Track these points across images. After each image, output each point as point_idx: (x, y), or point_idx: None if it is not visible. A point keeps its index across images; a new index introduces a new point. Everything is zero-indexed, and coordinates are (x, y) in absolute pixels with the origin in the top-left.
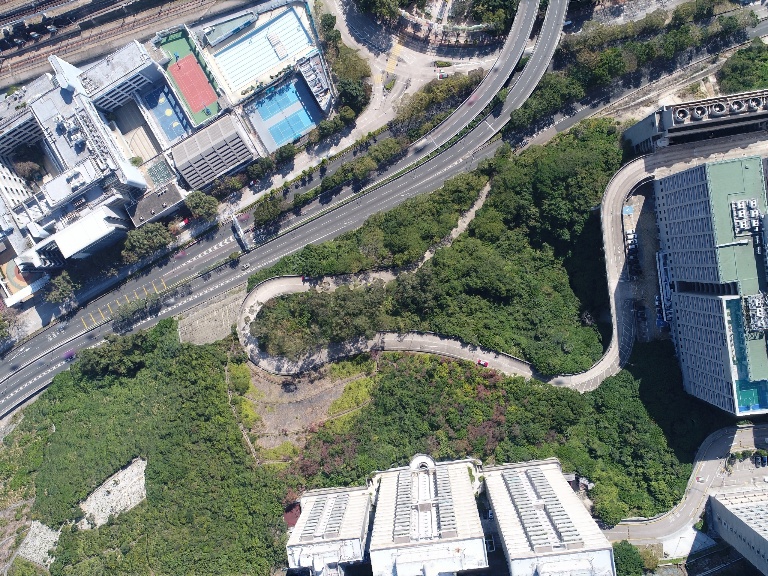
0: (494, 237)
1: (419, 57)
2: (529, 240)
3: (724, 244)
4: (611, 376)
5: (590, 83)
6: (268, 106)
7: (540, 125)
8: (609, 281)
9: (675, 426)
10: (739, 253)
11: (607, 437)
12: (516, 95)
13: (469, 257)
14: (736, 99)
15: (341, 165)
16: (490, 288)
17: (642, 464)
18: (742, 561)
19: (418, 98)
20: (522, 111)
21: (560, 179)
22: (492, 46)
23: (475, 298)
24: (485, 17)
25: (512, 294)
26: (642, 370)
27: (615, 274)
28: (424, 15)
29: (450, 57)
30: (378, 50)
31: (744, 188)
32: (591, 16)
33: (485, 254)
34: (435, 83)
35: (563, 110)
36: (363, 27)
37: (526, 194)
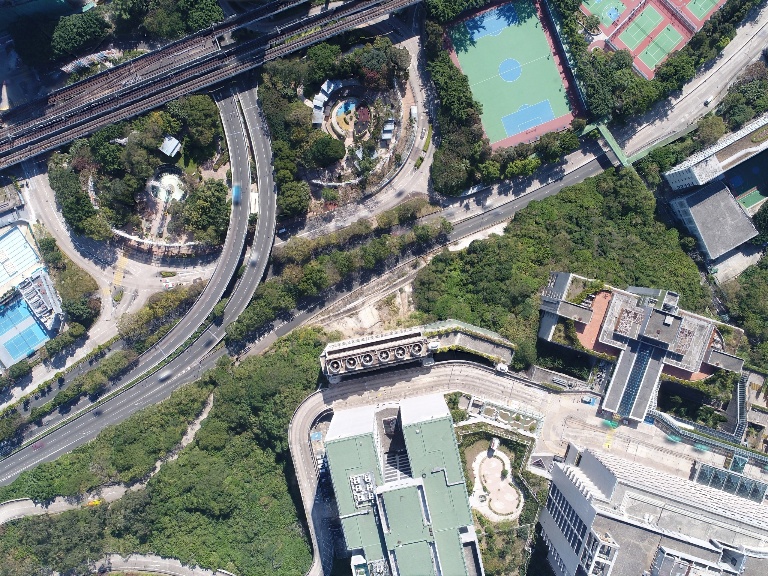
0: None
1: (144, 268)
2: (257, 442)
3: (346, 515)
4: None
5: (300, 293)
6: (1, 322)
7: (261, 332)
8: (305, 503)
9: None
10: (362, 522)
11: None
12: (235, 305)
13: (192, 471)
14: (383, 349)
15: (73, 379)
16: (204, 508)
17: None
18: None
19: (134, 320)
20: (235, 326)
21: (269, 395)
22: (214, 255)
23: (195, 515)
24: (196, 236)
25: (225, 512)
26: None
27: (310, 496)
28: (145, 229)
29: (174, 267)
30: (104, 264)
31: (360, 463)
32: (304, 223)
33: (205, 468)
34: (153, 300)
35: (281, 316)
36: (88, 242)
37: (244, 405)
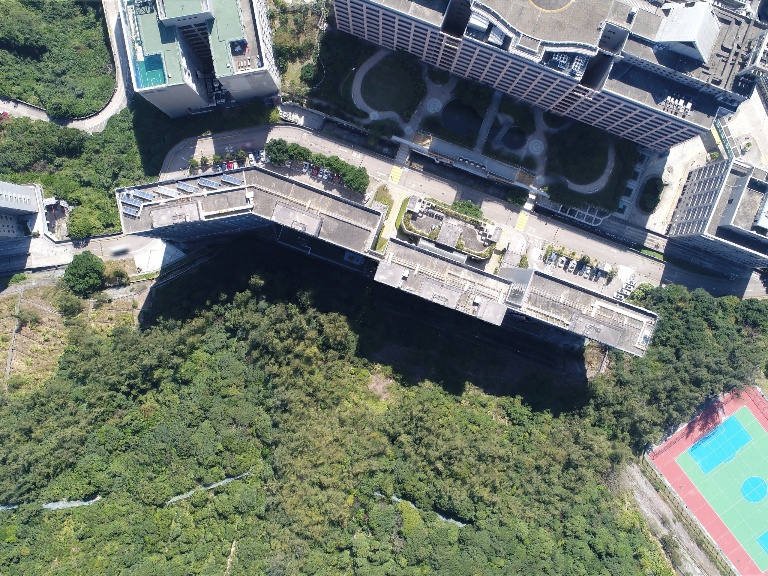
0: (41, 3)
1: None
2: (81, 9)
3: None
4: (116, 114)
5: None
6: None
7: None
8: (108, 18)
9: (151, 146)
10: None
11: (101, 168)
12: None
13: (4, 17)
14: None
15: None
16: (8, 38)
17: (116, 182)
18: (200, 265)
19: None
20: None
21: None
22: None
23: (1, 52)
24: None
25: (30, 43)
26: (136, 102)
27: (113, 11)
28: None
29: None
30: None
31: None
32: None
33: (17, 12)
34: None
35: None
36: None
37: None
